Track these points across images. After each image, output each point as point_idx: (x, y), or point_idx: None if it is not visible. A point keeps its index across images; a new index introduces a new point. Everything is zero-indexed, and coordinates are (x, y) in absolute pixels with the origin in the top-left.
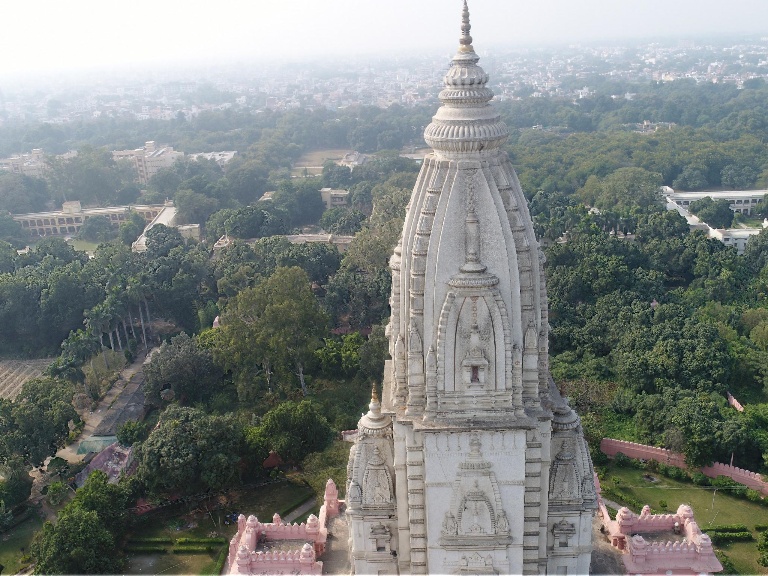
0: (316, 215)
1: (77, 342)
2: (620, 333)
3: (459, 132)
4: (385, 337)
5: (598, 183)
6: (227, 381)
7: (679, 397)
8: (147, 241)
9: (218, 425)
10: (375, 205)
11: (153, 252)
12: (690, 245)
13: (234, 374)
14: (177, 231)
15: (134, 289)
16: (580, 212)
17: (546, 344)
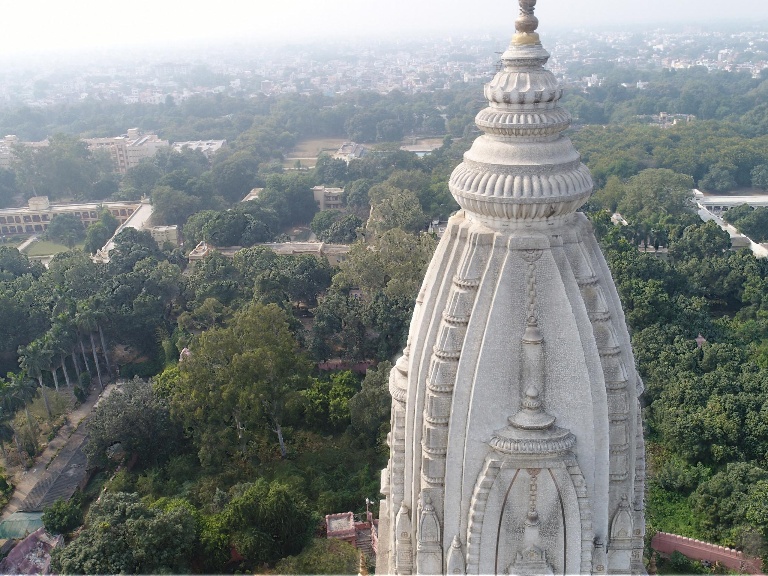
0: (307, 216)
1: (5, 390)
2: (664, 381)
3: (513, 186)
4: (381, 388)
5: (620, 185)
6: (191, 433)
7: (750, 479)
8: (110, 251)
9: (161, 528)
10: (373, 207)
11: (116, 264)
12: (736, 266)
13: (195, 433)
14: (150, 235)
15: (84, 317)
16: (602, 219)
17: (642, 525)
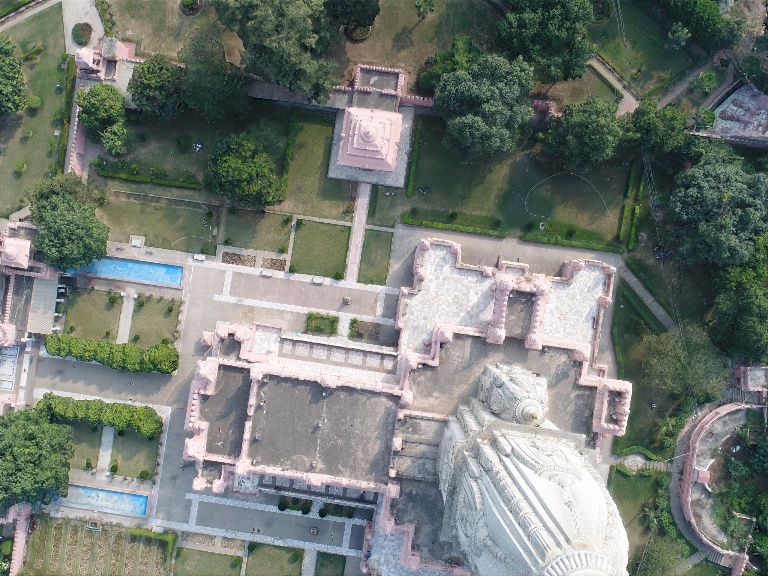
0: None
1: None
2: None
3: None
4: None
5: None
6: None
7: None
8: None
9: None
10: None
11: None
12: None
13: None
14: None
15: None
16: None
17: None
